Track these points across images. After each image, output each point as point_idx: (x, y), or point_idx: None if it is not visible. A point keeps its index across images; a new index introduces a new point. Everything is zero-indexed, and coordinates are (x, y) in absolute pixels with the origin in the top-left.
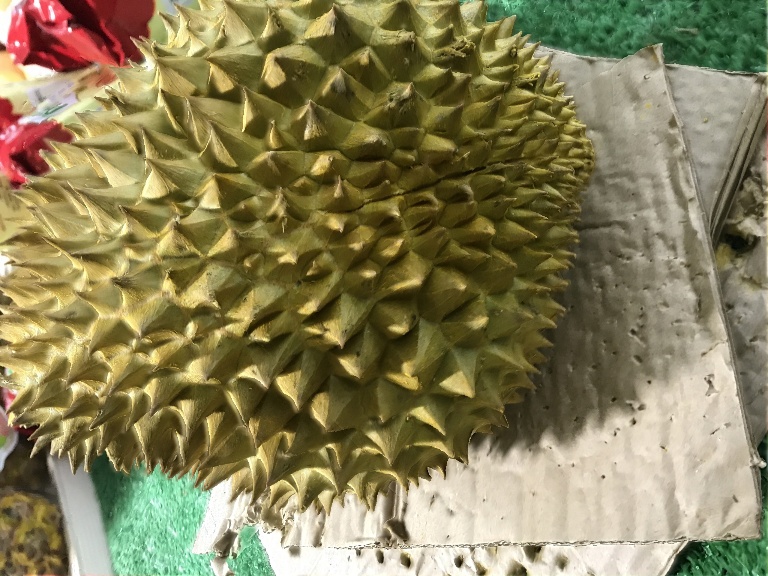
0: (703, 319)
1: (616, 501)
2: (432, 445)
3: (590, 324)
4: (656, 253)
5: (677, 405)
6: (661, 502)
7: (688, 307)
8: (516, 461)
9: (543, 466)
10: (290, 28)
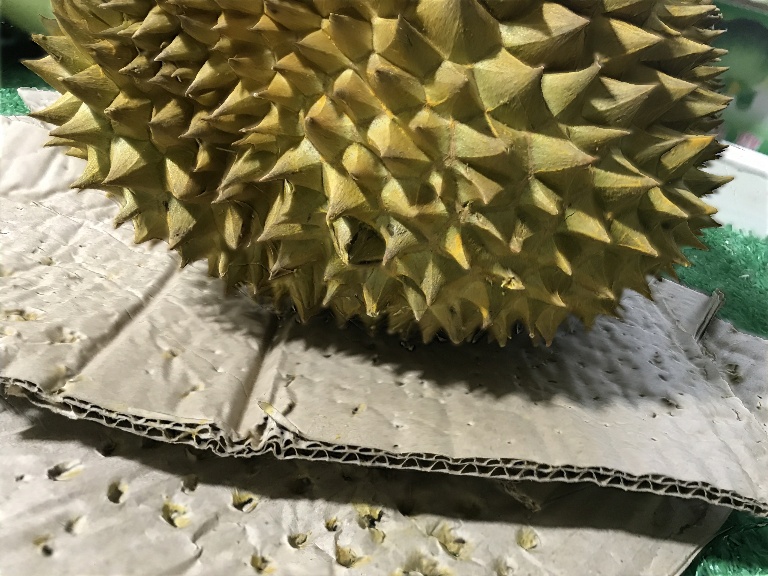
0: (710, 381)
1: (684, 456)
2: (632, 235)
3: (599, 346)
4: None
5: (714, 416)
6: (737, 467)
7: None
8: (521, 404)
9: (567, 415)
10: None
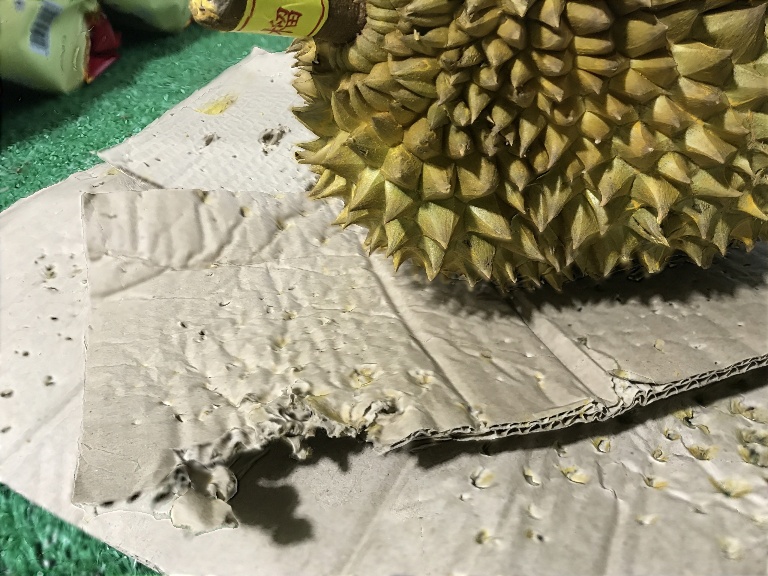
0: None
1: None
2: None
3: None
4: None
5: None
6: None
7: None
8: (753, 294)
9: None
10: None
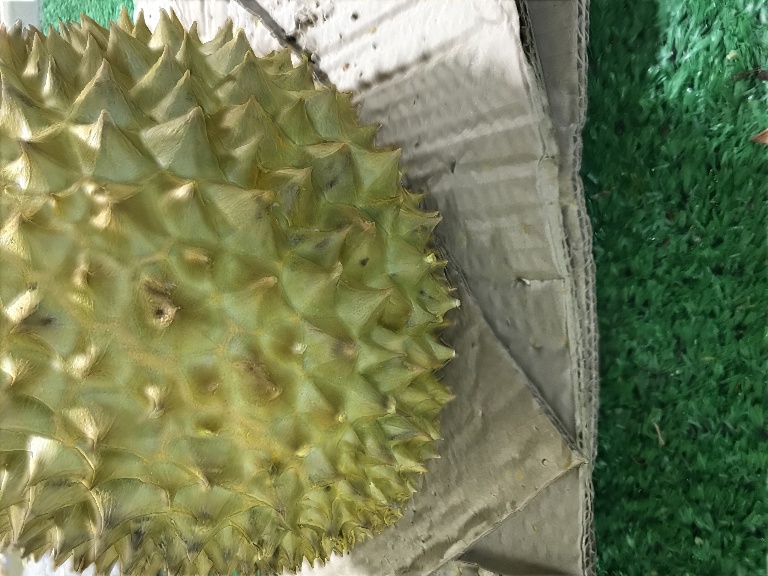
0: None
1: None
2: None
3: None
4: (418, 526)
5: None
6: None
7: (400, 564)
8: None
9: None
10: (62, 476)
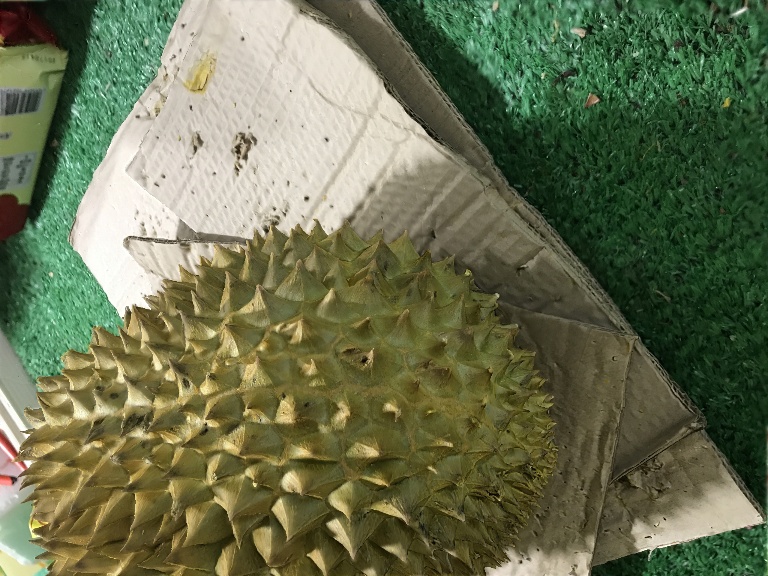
0: (584, 533)
1: None
2: None
3: None
4: (570, 481)
5: (550, 570)
6: None
7: (578, 522)
8: None
9: None
10: None
